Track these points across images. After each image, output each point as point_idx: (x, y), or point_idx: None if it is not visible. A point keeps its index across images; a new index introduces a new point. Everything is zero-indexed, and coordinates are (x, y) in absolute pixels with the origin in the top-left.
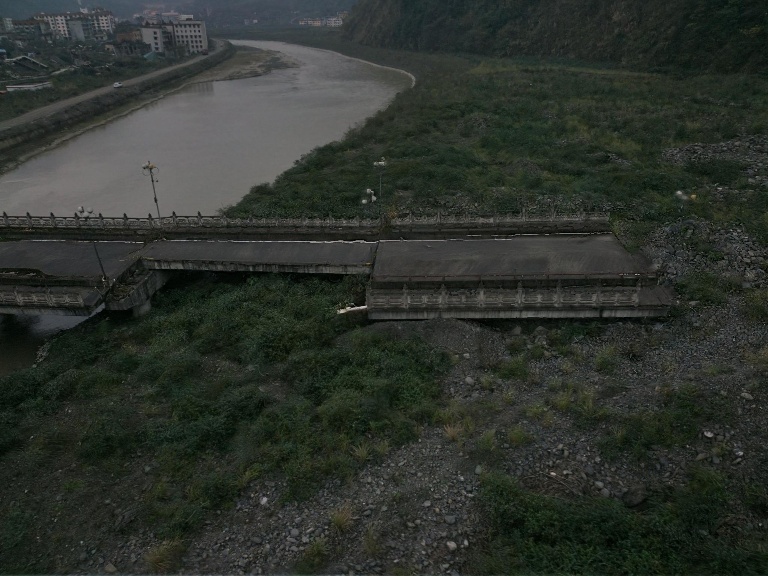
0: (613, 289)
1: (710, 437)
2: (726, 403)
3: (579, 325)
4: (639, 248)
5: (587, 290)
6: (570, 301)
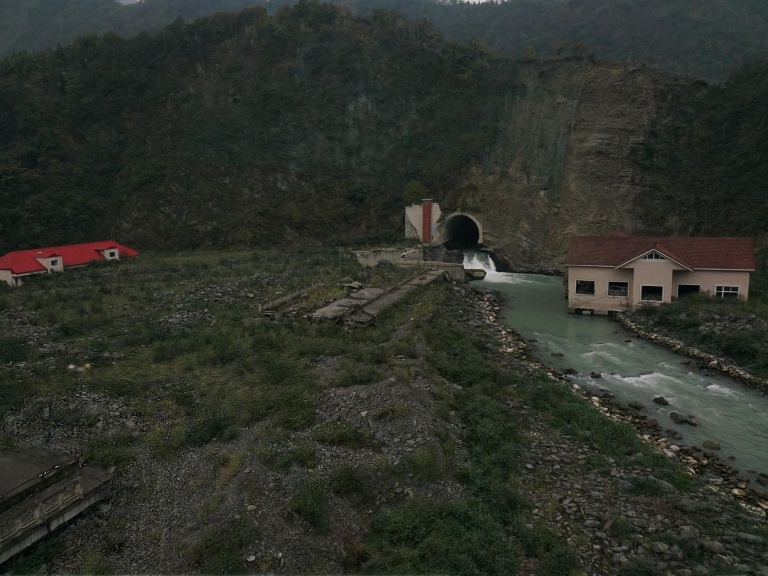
0: (54, 492)
1: (254, 560)
2: (245, 523)
3: (25, 558)
4: (13, 446)
5: (26, 509)
6: (10, 534)
